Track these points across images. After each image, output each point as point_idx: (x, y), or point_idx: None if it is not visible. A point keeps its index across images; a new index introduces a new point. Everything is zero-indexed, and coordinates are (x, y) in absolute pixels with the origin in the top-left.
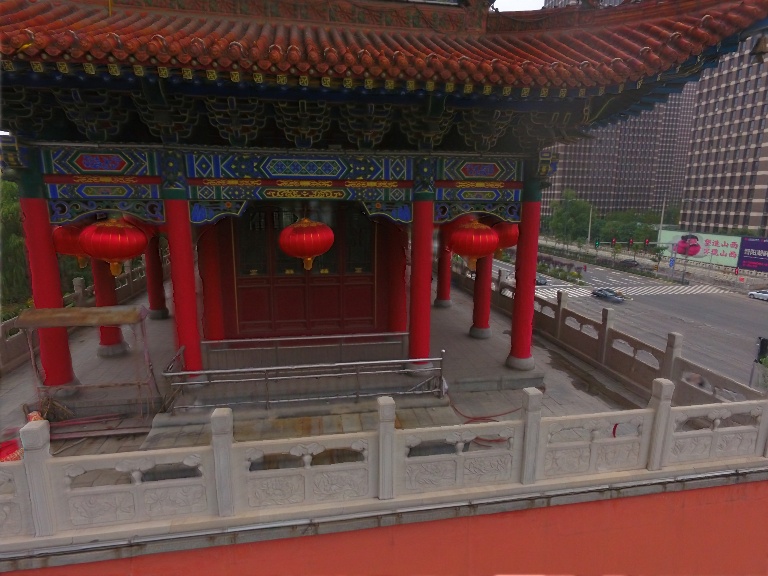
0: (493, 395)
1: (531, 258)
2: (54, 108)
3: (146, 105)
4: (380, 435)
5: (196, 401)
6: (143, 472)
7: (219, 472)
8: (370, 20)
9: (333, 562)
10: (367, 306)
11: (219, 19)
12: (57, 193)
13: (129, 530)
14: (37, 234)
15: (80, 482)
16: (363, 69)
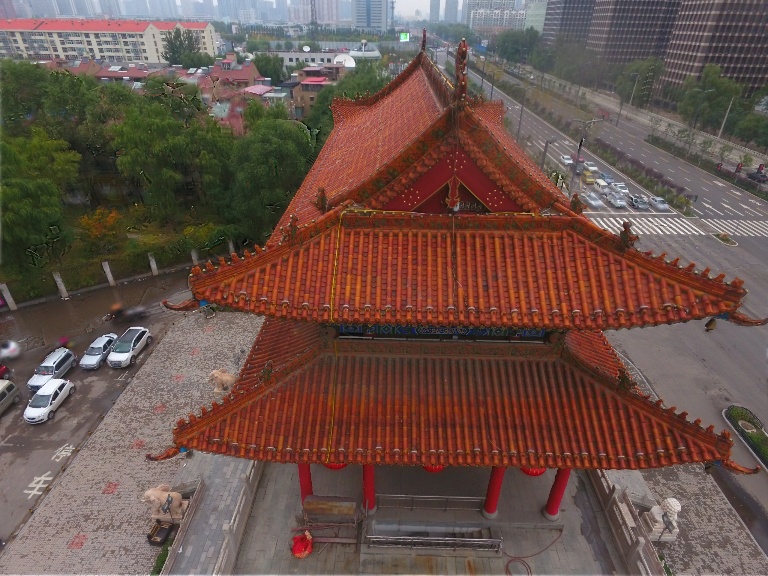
0: (530, 534)
1: (565, 477)
2: None
3: None
4: None
5: (373, 521)
6: None
7: None
8: (484, 353)
9: None
10: None
11: (394, 357)
12: None
13: None
14: None
15: None
16: None
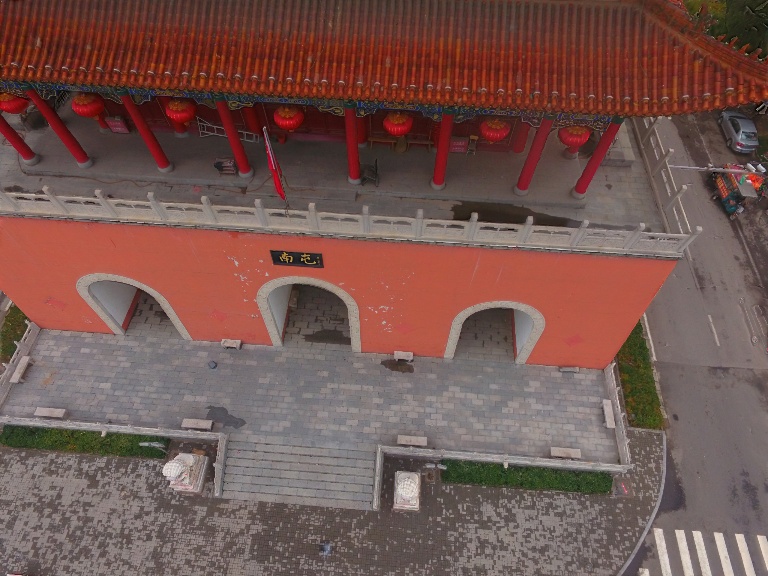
0: None
1: None
2: None
3: None
4: None
5: None
6: None
7: None
8: None
9: None
10: None
11: None
12: None
13: None
14: None
15: None
16: None
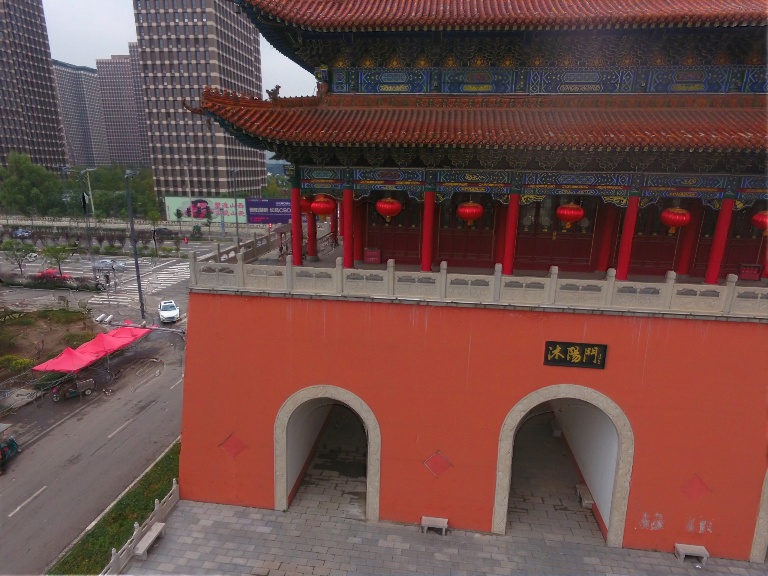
0: None
1: None
2: None
3: None
4: None
5: None
6: None
7: None
8: None
9: None
10: None
11: None
12: None
13: None
14: None
15: None
16: None
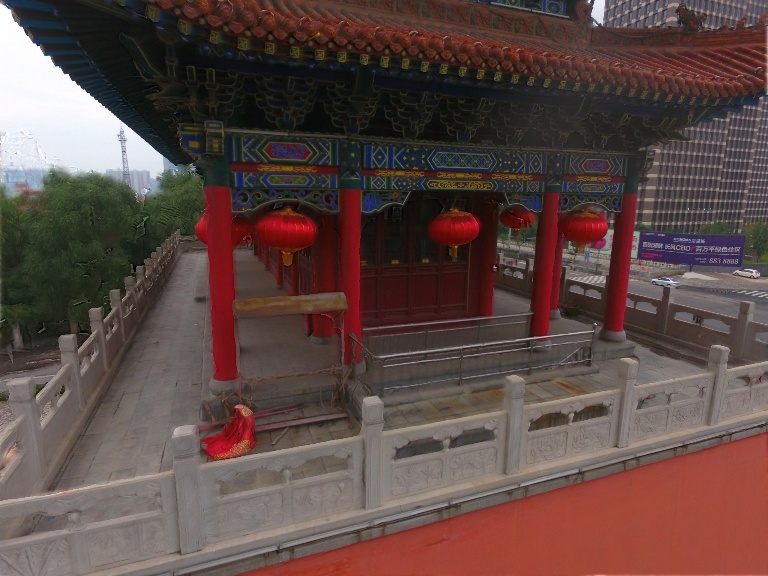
0: (603, 364)
1: (629, 243)
2: (246, 95)
3: (347, 96)
4: (626, 391)
5: None
6: (452, 439)
7: (512, 433)
8: (503, 26)
9: (592, 505)
10: (460, 293)
11: (379, 15)
12: (243, 182)
13: (444, 494)
14: (223, 224)
15: (333, 464)
16: (577, 73)
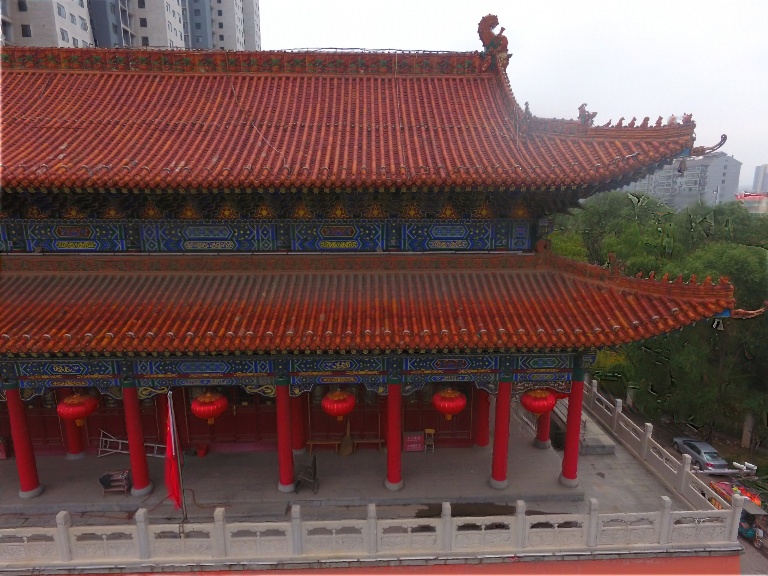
0: None
1: None
2: None
3: None
4: None
5: None
6: None
7: None
8: None
9: None
10: None
11: None
12: None
13: None
14: None
15: None
16: None
